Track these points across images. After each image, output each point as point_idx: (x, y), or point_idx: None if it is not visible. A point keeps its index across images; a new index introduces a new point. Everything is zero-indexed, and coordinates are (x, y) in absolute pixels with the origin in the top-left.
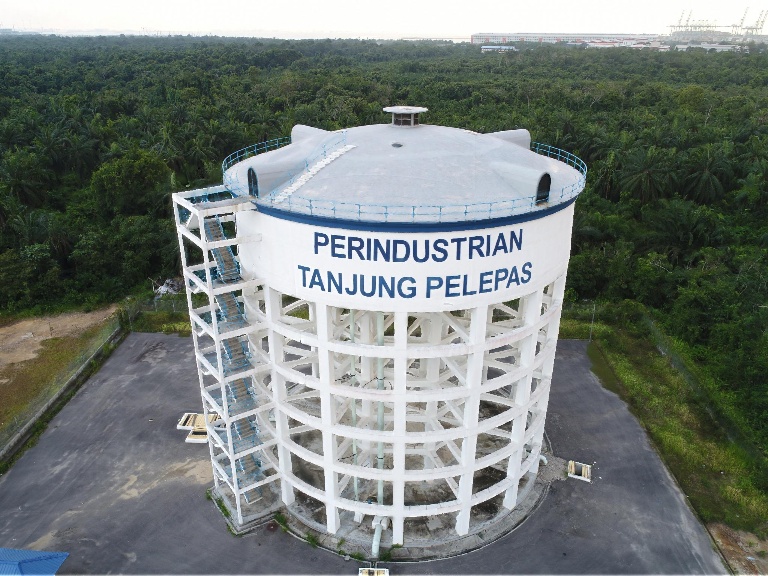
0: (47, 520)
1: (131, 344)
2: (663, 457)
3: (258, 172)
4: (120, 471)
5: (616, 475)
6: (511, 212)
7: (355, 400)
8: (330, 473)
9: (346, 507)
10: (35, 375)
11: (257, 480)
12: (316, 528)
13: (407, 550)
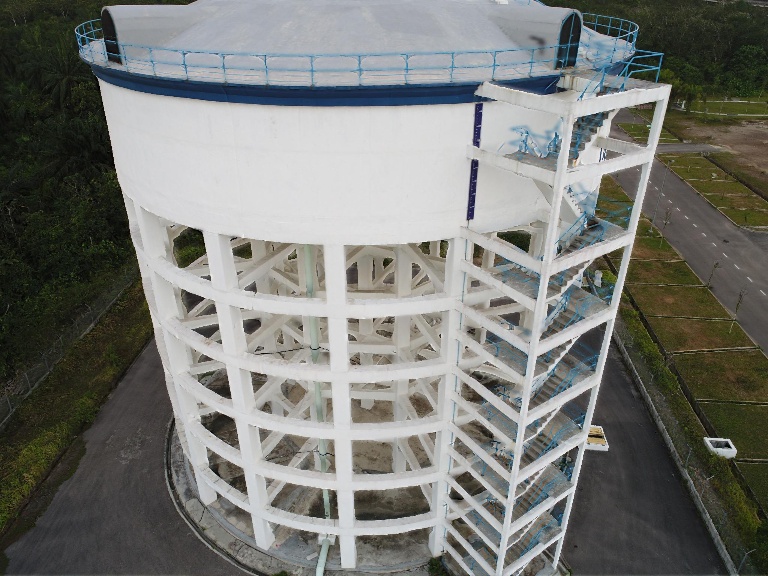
0: None
1: None
2: None
3: None
4: None
5: None
6: None
7: (289, 447)
8: None
9: None
10: None
11: None
12: None
13: None
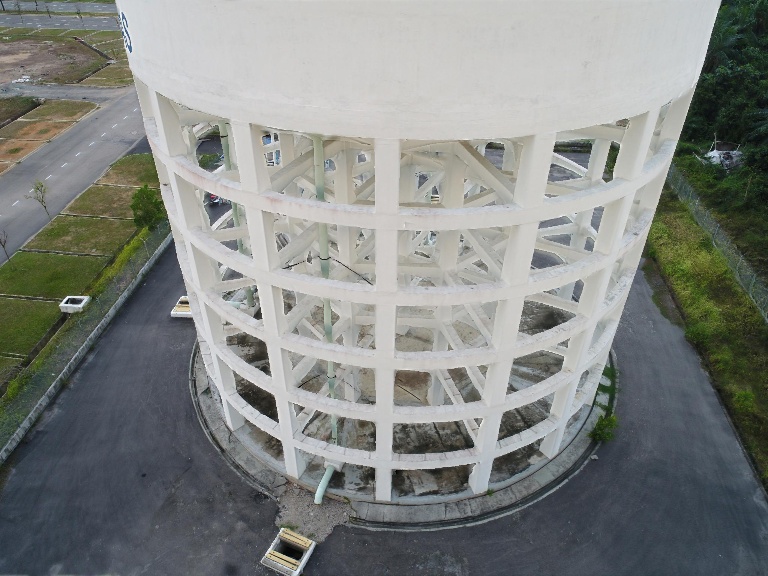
0: None
1: (574, 157)
2: None
3: None
4: None
5: None
6: None
7: None
8: None
9: None
10: None
11: None
12: None
13: None
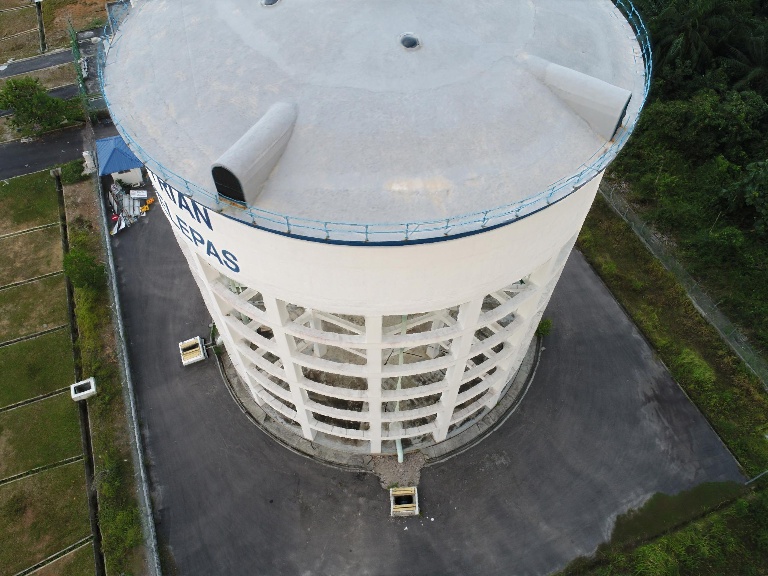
0: None
1: None
2: None
3: None
4: None
5: (419, 547)
6: (172, 177)
7: None
8: None
9: None
10: None
11: None
12: None
13: (230, 364)
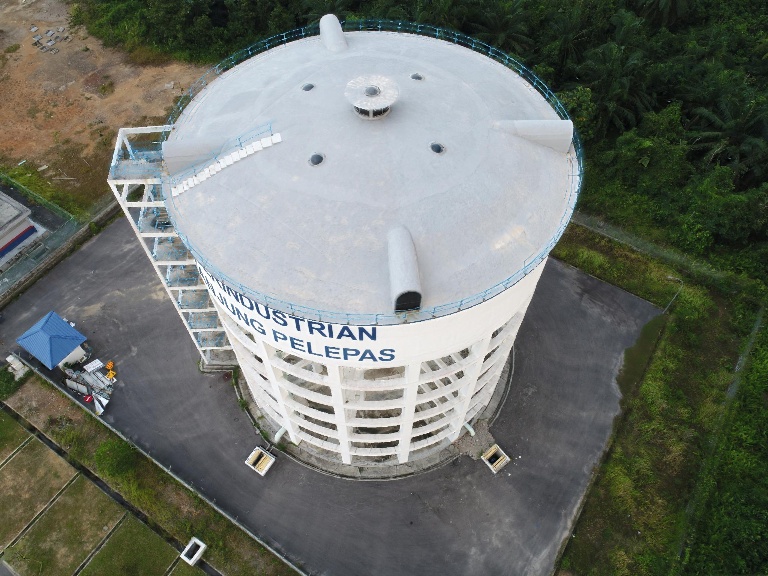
0: (102, 292)
1: None
2: (591, 488)
3: (164, 155)
4: (162, 270)
5: (526, 480)
6: None
7: None
8: (247, 380)
9: (260, 404)
10: (154, 138)
11: (217, 345)
12: (252, 396)
13: (299, 451)
